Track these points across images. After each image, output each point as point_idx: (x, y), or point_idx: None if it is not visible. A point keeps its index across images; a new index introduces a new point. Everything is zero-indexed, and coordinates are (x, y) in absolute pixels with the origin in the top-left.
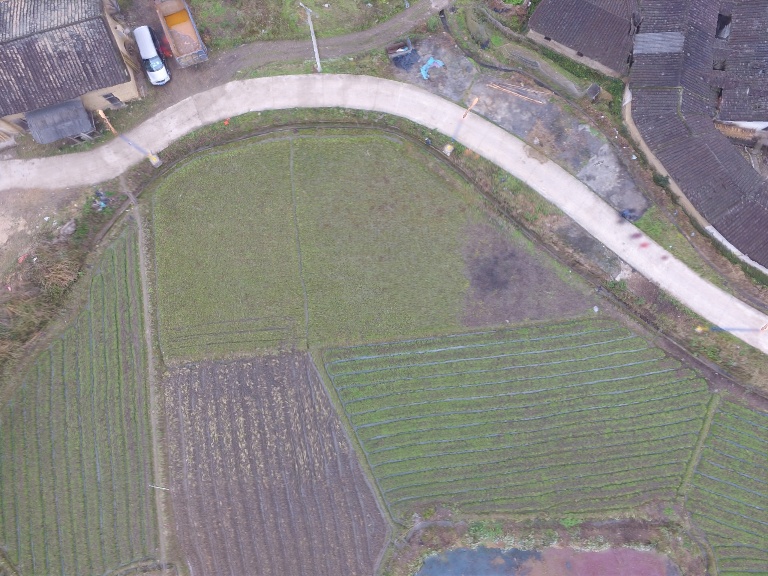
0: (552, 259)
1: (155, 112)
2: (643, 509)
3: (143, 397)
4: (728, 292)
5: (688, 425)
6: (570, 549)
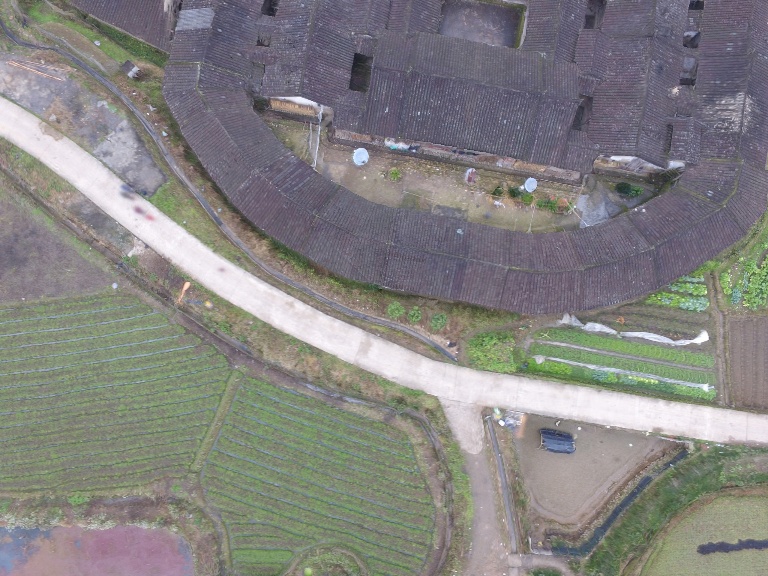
0: (72, 236)
1: None
2: (151, 486)
3: None
4: (241, 267)
5: (204, 402)
6: (79, 527)
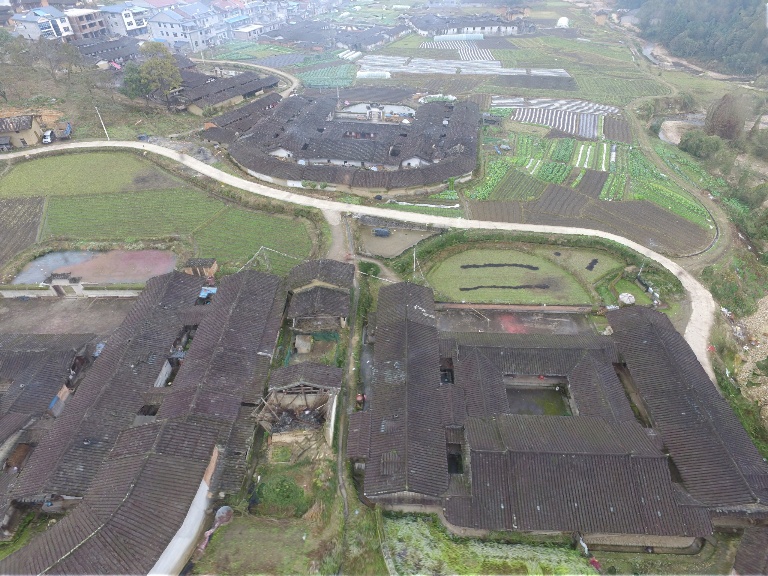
0: (172, 175)
1: None
2: None
3: None
4: (241, 178)
5: None
6: (124, 250)
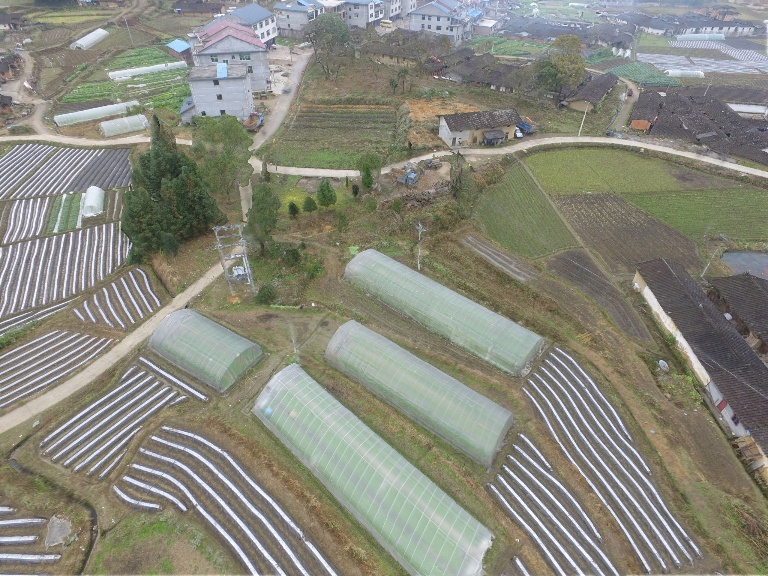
0: None
1: (520, 142)
2: None
3: (546, 202)
4: None
5: None
6: None
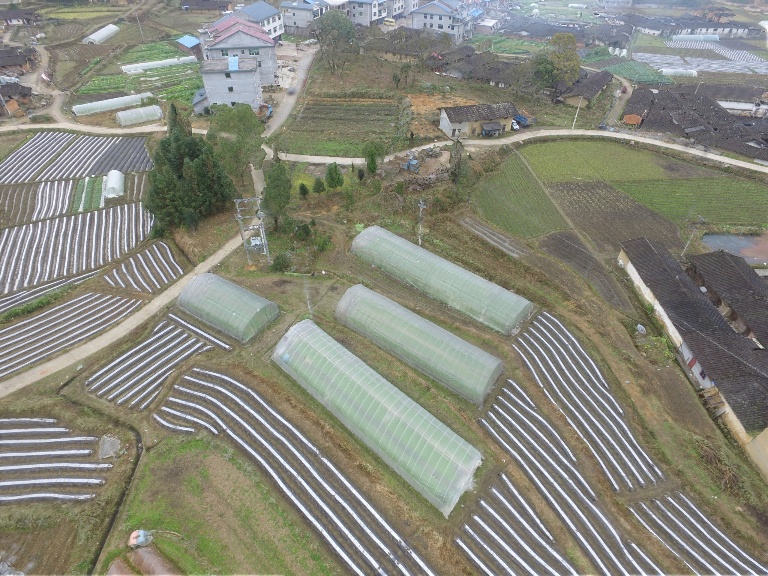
0: None
1: (516, 134)
2: None
3: None
4: None
5: None
6: None
